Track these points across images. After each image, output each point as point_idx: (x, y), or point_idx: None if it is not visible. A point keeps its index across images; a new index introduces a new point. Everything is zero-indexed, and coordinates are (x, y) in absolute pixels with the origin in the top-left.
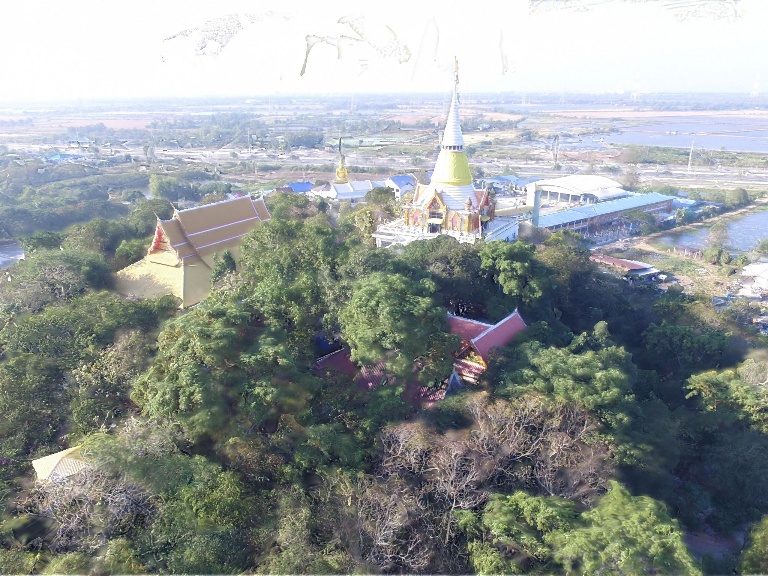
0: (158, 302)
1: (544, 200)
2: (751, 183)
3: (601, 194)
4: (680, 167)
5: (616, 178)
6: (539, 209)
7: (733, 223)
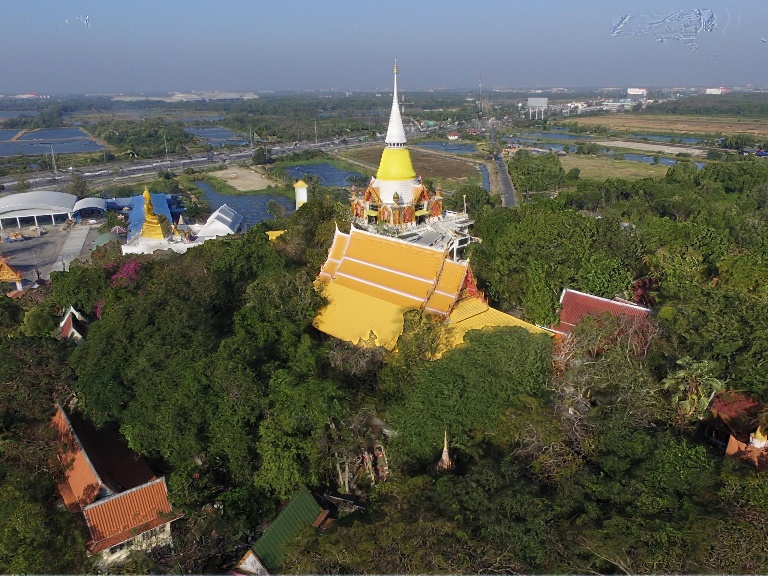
0: None
1: (16, 229)
2: (129, 177)
3: (99, 205)
4: (47, 174)
5: (64, 190)
6: (45, 237)
7: (217, 206)
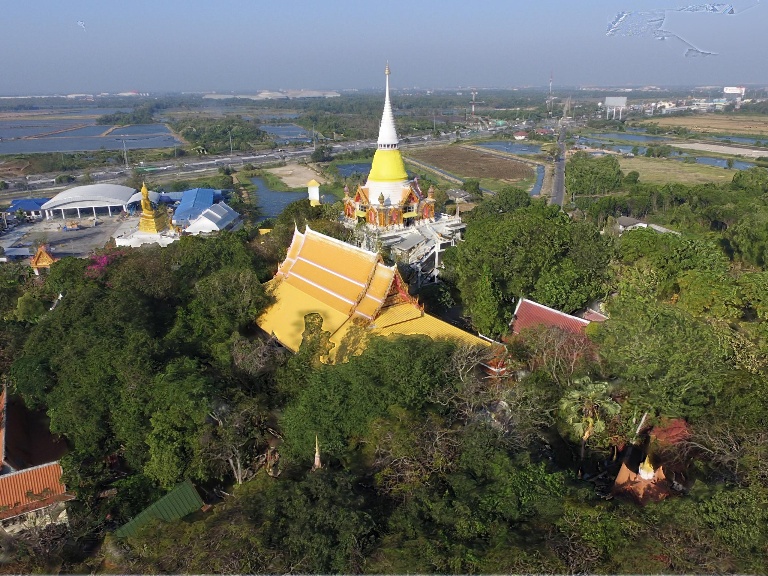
0: None
1: (76, 219)
2: (192, 172)
3: (151, 199)
4: None
5: (124, 183)
6: (98, 227)
7: (264, 201)
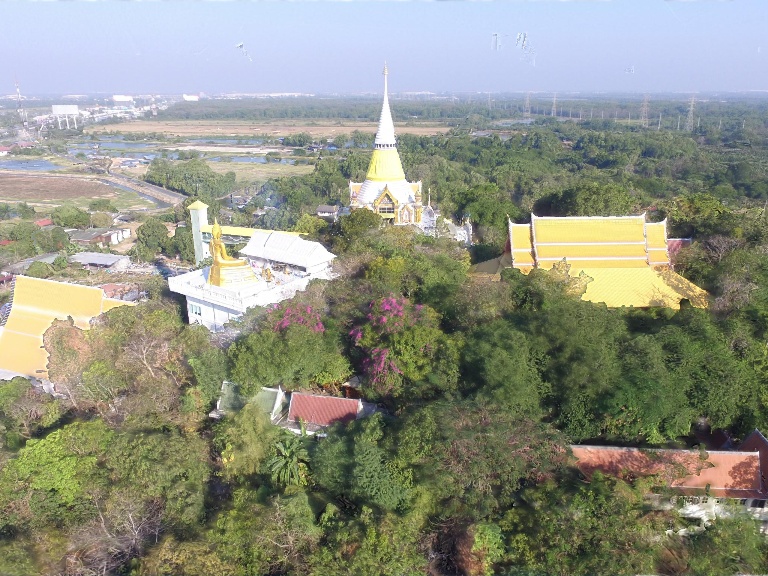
0: (711, 213)
1: None
2: None
3: None
4: None
5: None
6: None
7: None
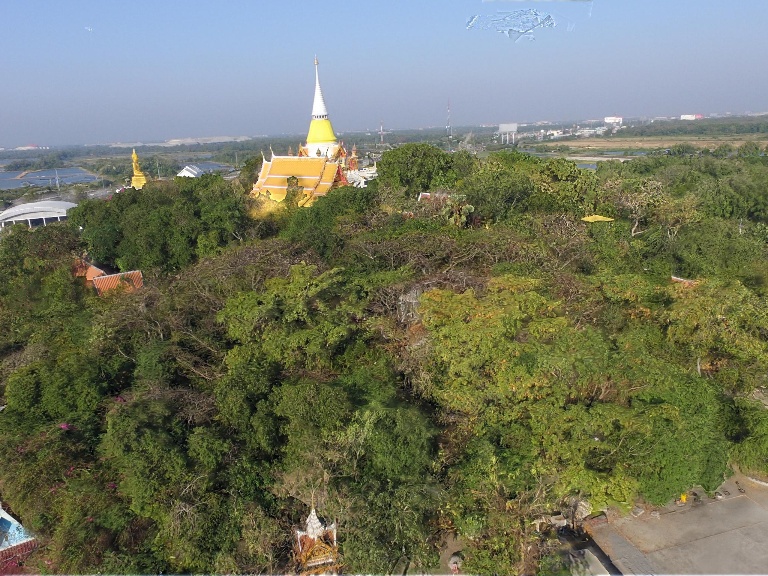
0: None
1: None
2: None
3: None
4: None
5: (68, 200)
6: None
7: None
